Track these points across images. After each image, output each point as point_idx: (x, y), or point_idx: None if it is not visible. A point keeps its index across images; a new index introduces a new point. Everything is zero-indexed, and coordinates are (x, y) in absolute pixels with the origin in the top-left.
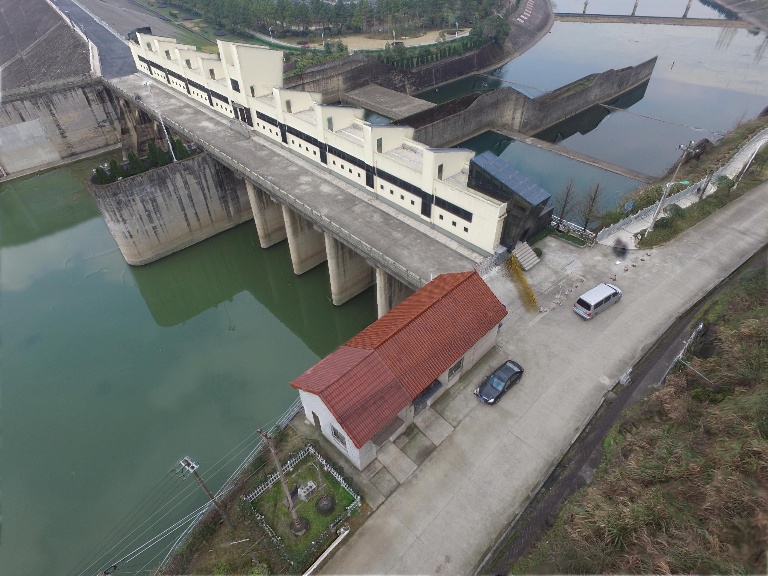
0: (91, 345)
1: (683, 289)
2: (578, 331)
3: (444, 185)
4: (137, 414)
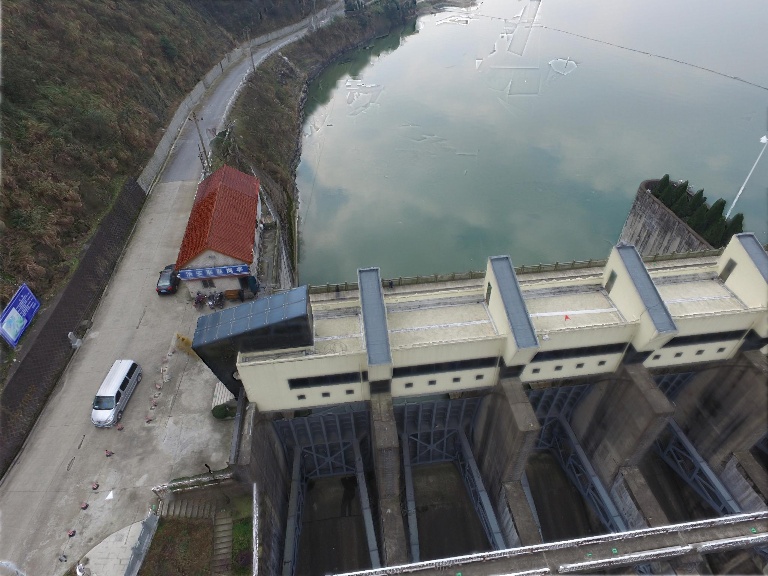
0: (509, 236)
1: (7, 513)
2: (130, 357)
3: (341, 304)
4: (423, 246)
